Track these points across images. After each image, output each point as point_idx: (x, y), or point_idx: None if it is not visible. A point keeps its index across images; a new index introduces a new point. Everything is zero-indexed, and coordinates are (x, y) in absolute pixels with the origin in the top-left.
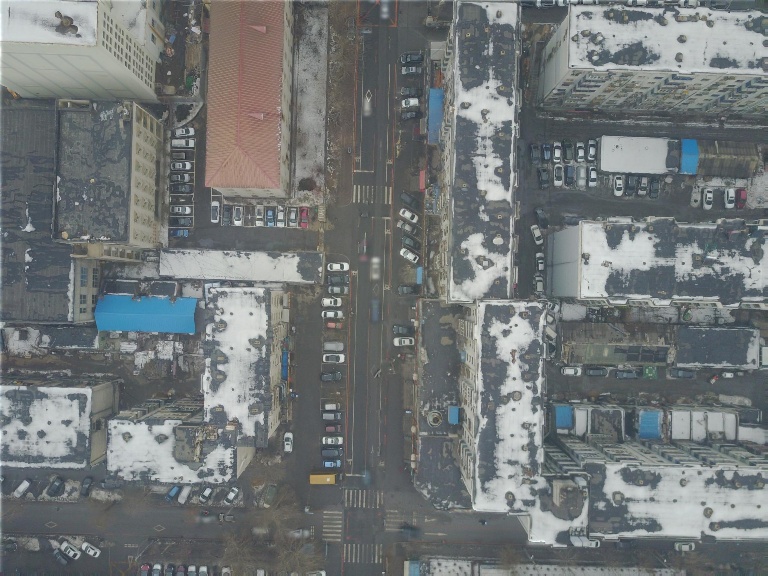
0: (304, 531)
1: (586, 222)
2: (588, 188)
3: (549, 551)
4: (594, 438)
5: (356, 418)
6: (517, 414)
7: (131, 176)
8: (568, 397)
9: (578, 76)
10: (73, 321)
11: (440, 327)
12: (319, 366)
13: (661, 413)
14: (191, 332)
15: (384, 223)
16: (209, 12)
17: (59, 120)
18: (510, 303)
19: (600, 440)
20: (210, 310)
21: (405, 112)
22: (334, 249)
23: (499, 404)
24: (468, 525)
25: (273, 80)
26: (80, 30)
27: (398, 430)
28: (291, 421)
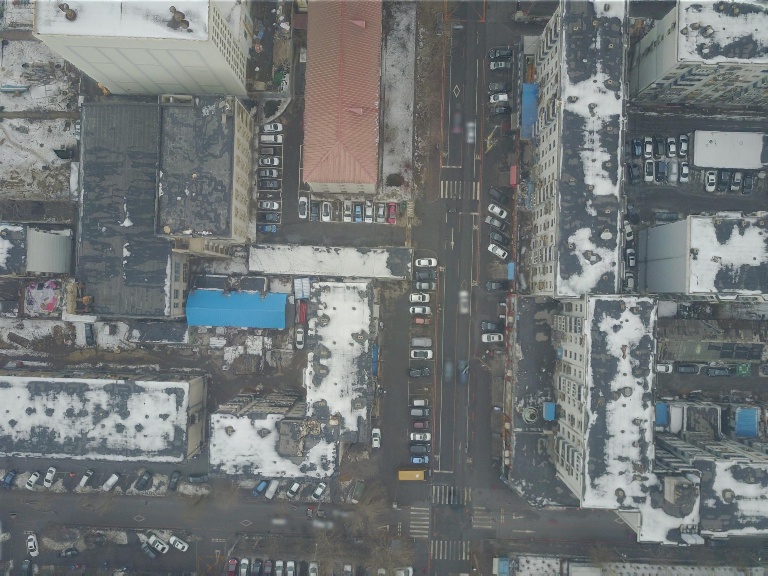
0: (391, 527)
1: (695, 217)
2: (679, 184)
3: (639, 549)
4: (692, 435)
5: (444, 414)
6: (628, 410)
7: (233, 171)
8: (659, 394)
9: (683, 70)
10: (169, 315)
11: (535, 323)
12: (407, 362)
13: (758, 411)
14: (281, 327)
15: (472, 219)
16: (300, 8)
17: (162, 115)
18: (621, 298)
19: (698, 437)
20: (313, 305)
21: (493, 107)
22: (421, 245)
23: (609, 400)
24: (557, 523)
25: (371, 75)
26: (191, 25)
27: (486, 426)
28: (379, 417)
